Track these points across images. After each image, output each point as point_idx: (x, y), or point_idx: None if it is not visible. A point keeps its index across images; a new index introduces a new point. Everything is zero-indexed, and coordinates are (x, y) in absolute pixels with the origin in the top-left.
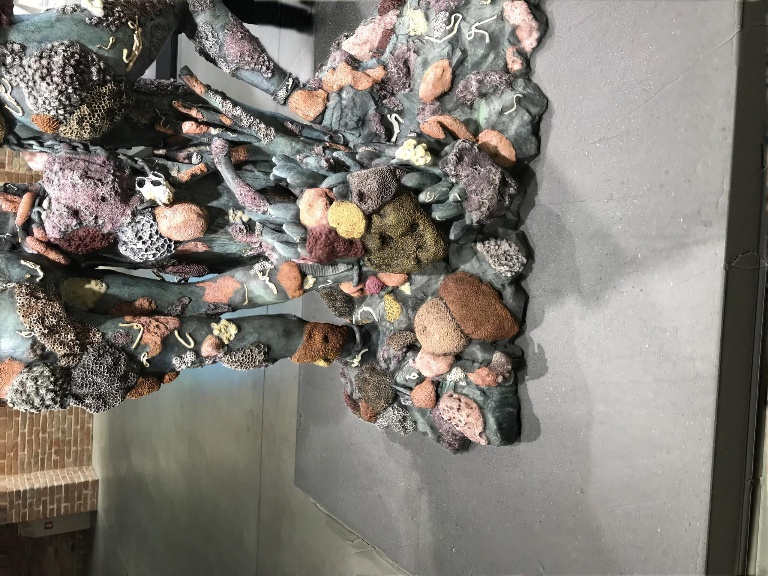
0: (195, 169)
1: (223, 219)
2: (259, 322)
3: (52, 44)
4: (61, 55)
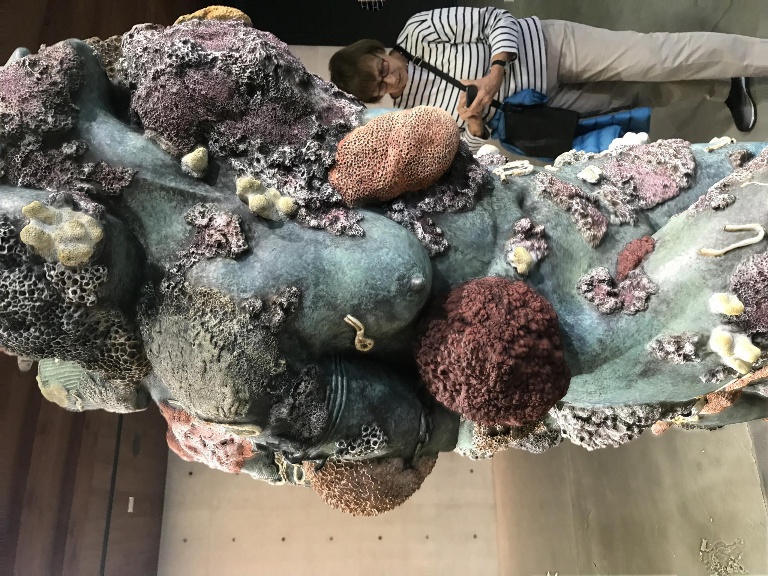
0: (761, 375)
1: (761, 379)
2: (731, 410)
3: (614, 411)
4: (621, 434)
